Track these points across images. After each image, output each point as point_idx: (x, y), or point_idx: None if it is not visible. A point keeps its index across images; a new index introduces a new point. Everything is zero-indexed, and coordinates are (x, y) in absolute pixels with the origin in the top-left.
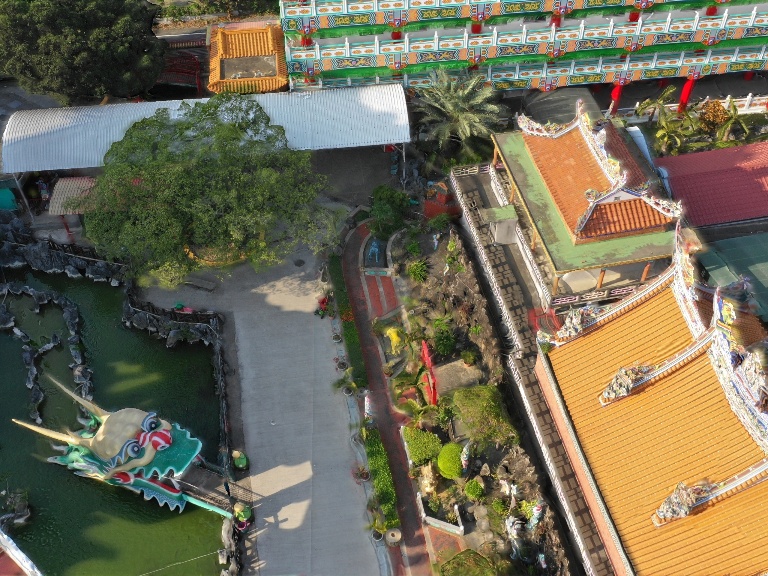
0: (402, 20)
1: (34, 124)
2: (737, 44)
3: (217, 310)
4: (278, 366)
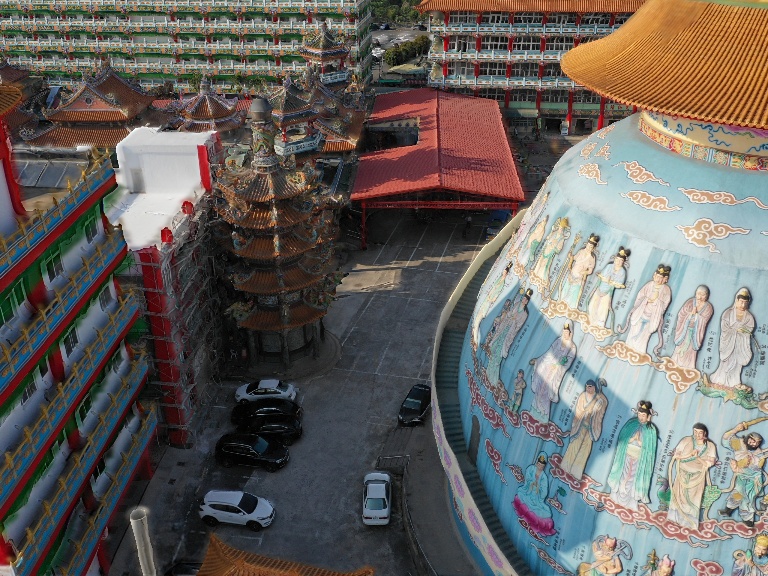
0: (4, 50)
1: None
2: (147, 76)
3: None
4: None
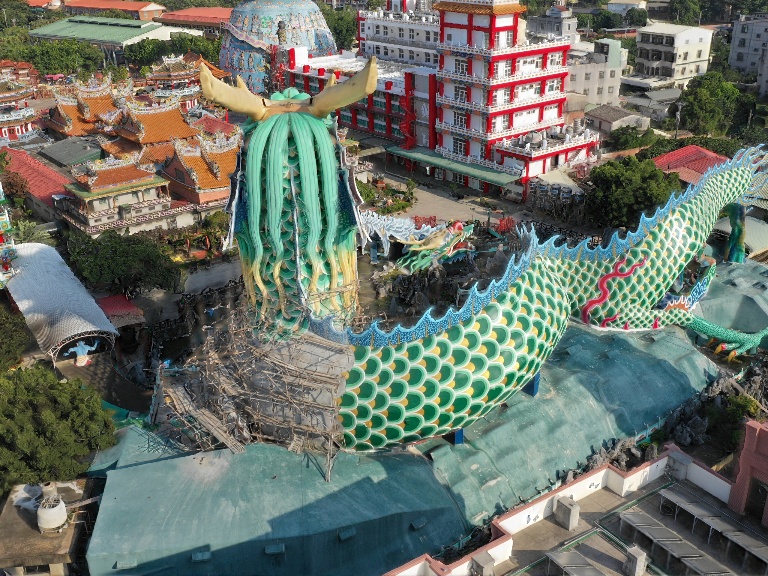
0: None
1: (77, 325)
2: None
3: (175, 304)
4: (202, 284)
